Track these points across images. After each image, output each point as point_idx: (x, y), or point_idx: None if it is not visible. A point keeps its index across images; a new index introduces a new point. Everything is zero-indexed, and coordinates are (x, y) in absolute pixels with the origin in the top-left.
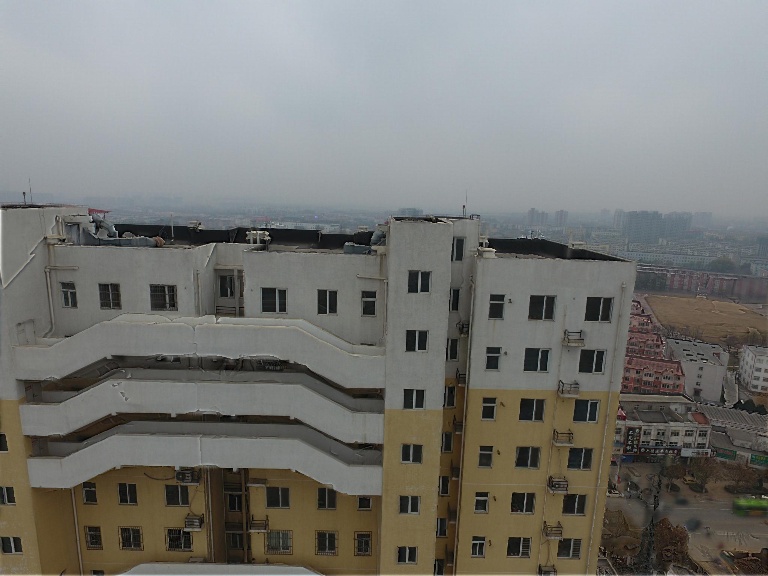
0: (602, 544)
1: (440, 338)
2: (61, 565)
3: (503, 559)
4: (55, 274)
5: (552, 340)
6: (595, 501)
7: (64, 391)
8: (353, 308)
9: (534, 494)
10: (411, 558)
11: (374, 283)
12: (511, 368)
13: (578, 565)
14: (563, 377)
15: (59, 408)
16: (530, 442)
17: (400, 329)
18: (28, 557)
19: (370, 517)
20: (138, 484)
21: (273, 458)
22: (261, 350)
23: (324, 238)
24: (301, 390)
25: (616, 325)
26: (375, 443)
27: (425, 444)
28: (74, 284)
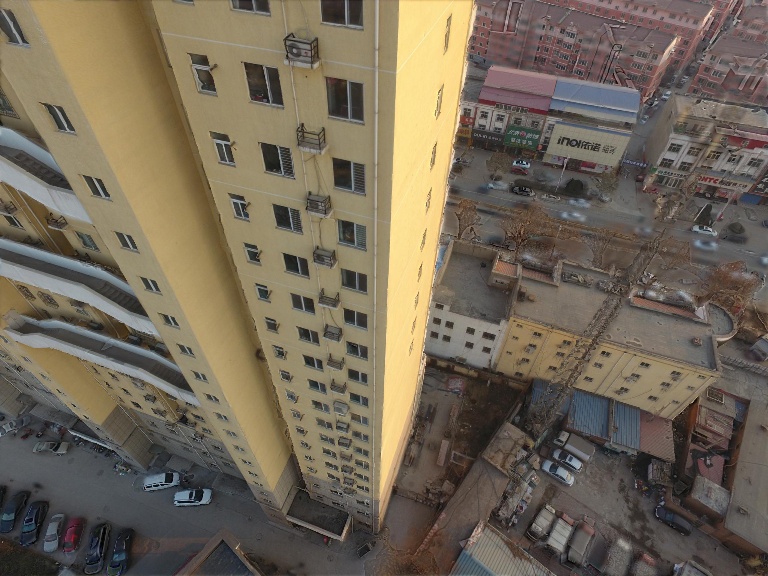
0: (654, 272)
1: None
2: None
3: (259, 173)
4: None
5: None
6: (374, 97)
7: None
8: None
9: (277, 70)
10: (69, 125)
11: None
12: None
13: (362, 203)
14: None
15: None
16: None
17: None
18: None
19: None
20: None
21: None
22: None
23: None
24: None
25: None
26: None
27: None
28: None
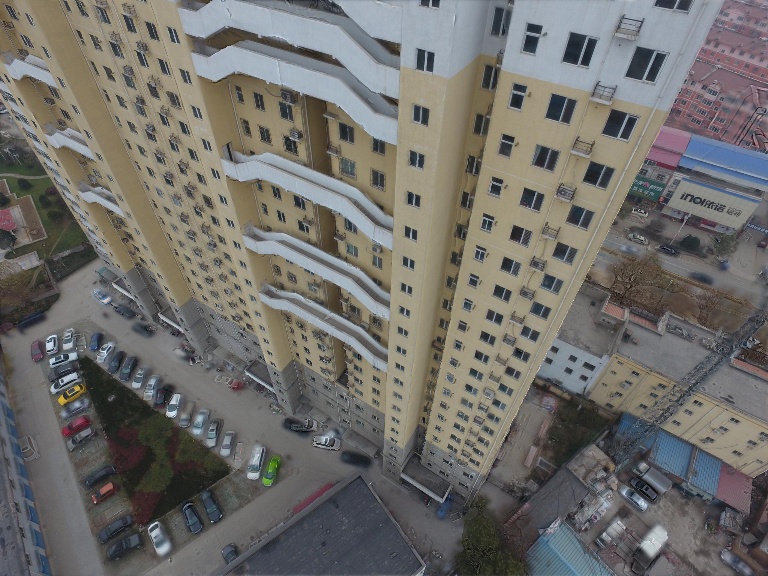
0: (761, 339)
1: None
2: (228, 138)
3: (505, 240)
4: None
5: (604, 27)
6: (600, 220)
7: None
8: None
9: (544, 195)
10: (417, 203)
11: None
12: (548, 55)
13: (568, 269)
14: (604, 78)
15: (197, 15)
16: (551, 143)
17: None
18: (206, 123)
19: None
20: (264, 96)
21: (324, 91)
22: None
23: None
24: (339, 32)
25: (694, 18)
26: (393, 97)
27: (431, 109)
28: None
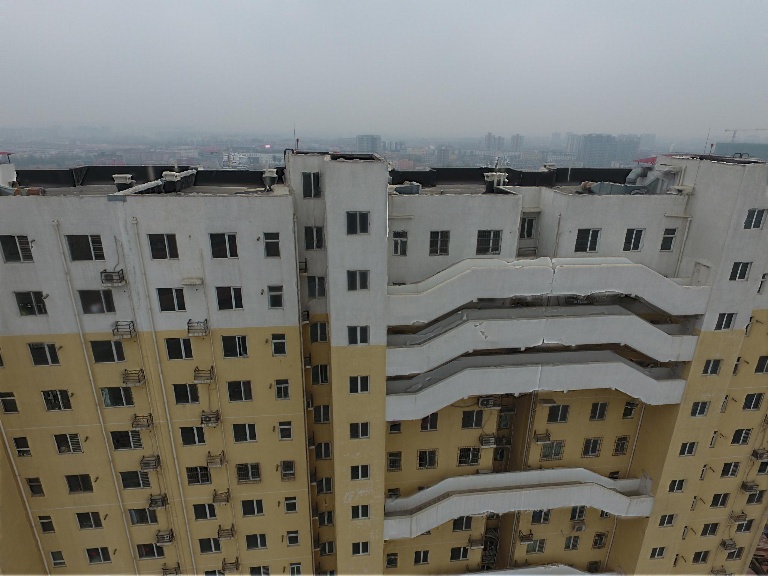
0: None
1: (760, 268)
2: None
3: (728, 447)
4: (390, 224)
5: None
6: None
7: (401, 334)
8: (655, 245)
9: (762, 394)
10: (689, 451)
11: (678, 221)
12: None
13: None
14: None
15: (422, 349)
16: None
17: (730, 262)
18: (374, 481)
19: (631, 423)
20: (440, 412)
21: (599, 379)
22: (609, 286)
23: (521, 177)
24: (635, 320)
25: None
26: (685, 361)
27: (725, 359)
28: (407, 233)
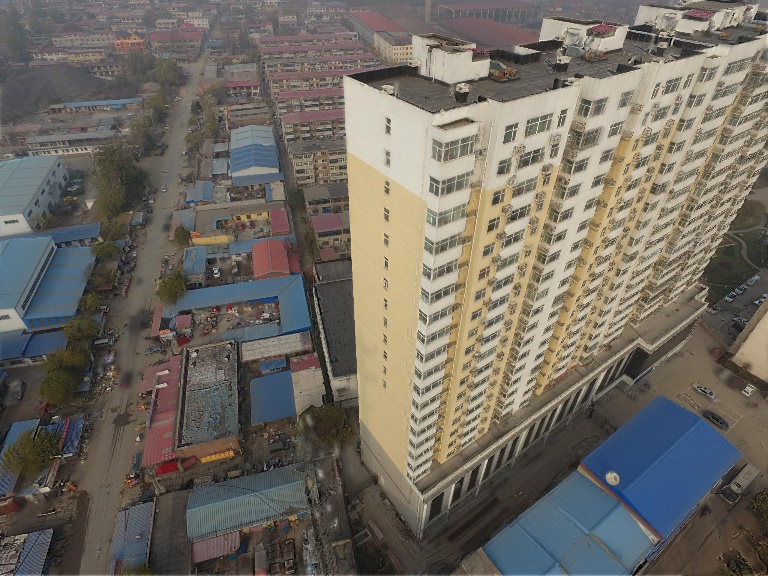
0: None
1: None
2: None
3: None
4: None
5: None
6: None
7: None
8: None
9: None
10: None
11: None
12: None
13: None
14: None
15: None
16: None
17: None
18: None
19: None
20: None
21: None
22: None
23: None
24: None
25: None
26: None
27: None
28: None
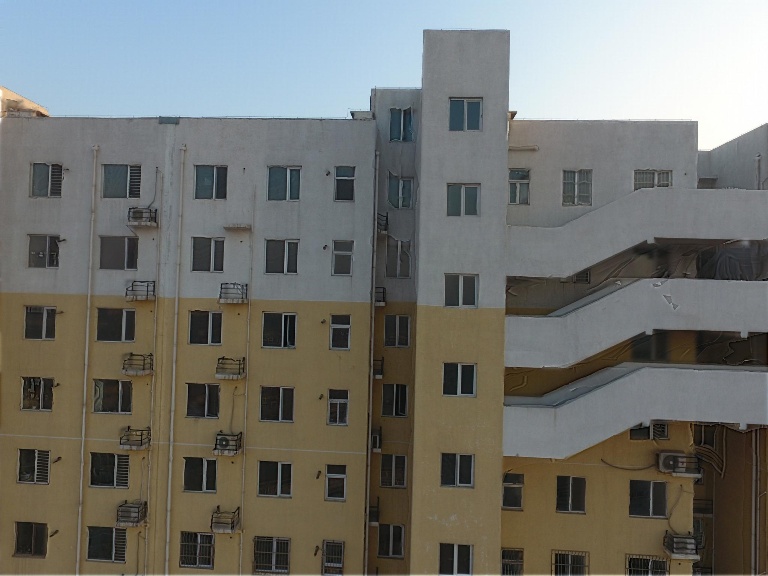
0: None
1: None
2: None
3: None
4: None
5: None
6: None
7: (524, 315)
8: None
9: None
10: None
11: None
12: None
13: None
14: None
15: (565, 322)
16: None
17: None
18: None
19: None
20: (589, 478)
21: None
22: None
23: None
24: None
25: None
26: None
27: None
28: (529, 171)
